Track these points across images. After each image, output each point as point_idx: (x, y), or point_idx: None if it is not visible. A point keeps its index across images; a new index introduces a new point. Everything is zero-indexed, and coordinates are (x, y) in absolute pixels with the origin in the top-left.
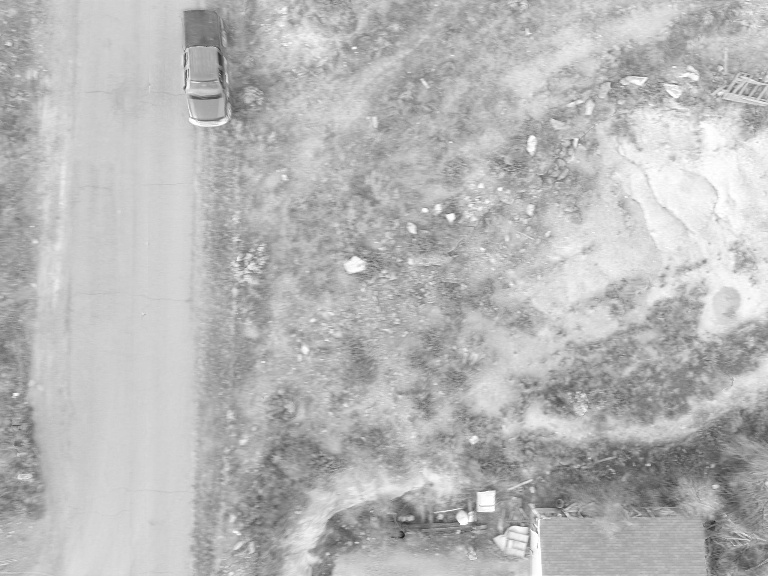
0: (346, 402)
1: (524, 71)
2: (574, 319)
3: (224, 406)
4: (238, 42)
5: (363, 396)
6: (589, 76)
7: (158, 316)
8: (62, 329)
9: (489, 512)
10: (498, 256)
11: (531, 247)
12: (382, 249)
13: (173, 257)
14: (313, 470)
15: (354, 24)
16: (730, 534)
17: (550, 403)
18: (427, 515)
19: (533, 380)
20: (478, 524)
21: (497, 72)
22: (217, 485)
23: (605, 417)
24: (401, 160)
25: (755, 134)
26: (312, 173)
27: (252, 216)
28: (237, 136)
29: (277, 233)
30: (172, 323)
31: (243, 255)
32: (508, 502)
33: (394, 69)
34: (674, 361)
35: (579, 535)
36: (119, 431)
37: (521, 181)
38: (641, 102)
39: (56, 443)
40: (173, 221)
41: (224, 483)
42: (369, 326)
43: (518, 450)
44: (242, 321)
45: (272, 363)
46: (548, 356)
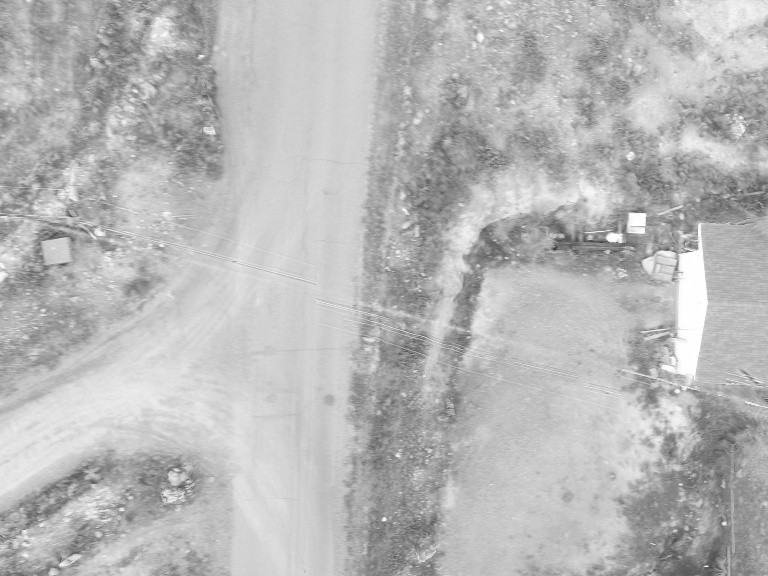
0: (513, 99)
1: None
2: (732, 48)
3: (401, 83)
4: None
5: (529, 96)
6: None
7: None
8: None
9: (638, 236)
10: None
11: None
12: None
13: None
14: (479, 163)
15: None
16: None
17: (707, 125)
18: (577, 234)
19: (691, 102)
20: (628, 245)
21: None
22: (391, 159)
23: (758, 148)
24: None
25: None
26: None
27: None
28: None
29: None
30: None
31: None
32: (657, 228)
33: None
34: None
35: (740, 238)
36: (298, 100)
37: None
38: None
39: (237, 108)
40: None
41: (398, 158)
42: (543, 20)
43: (673, 170)
44: (423, 0)
45: (448, 46)
46: (705, 82)
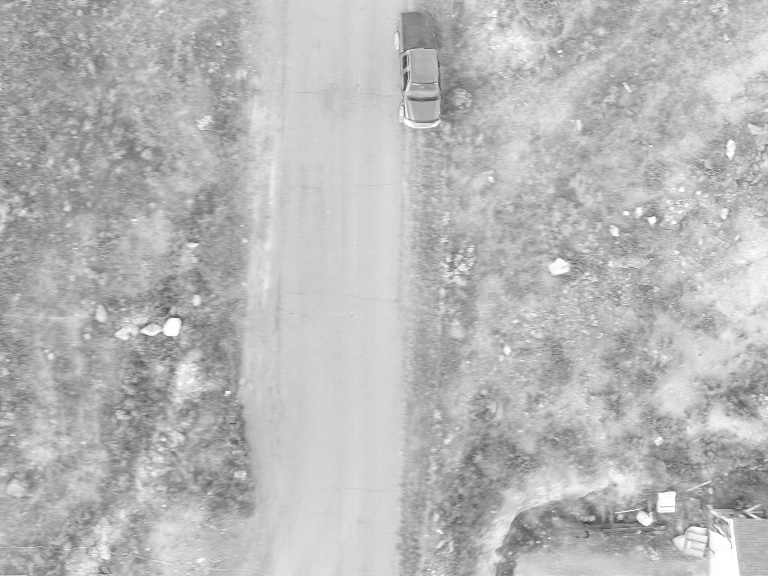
0: (542, 403)
1: (722, 76)
2: (755, 322)
3: (431, 406)
4: (445, 44)
5: (557, 397)
6: None
7: (366, 316)
8: (272, 328)
9: (668, 513)
10: (689, 259)
11: (721, 250)
12: (586, 251)
13: (381, 257)
14: (509, 470)
15: (560, 28)
16: None
17: (733, 405)
18: (608, 515)
19: (716, 382)
20: (658, 524)
21: (696, 77)
22: (423, 484)
23: None
24: (603, 163)
25: None
26: (517, 175)
27: (459, 217)
28: (445, 138)
29: (483, 234)
30: (380, 323)
31: (452, 256)
32: (686, 503)
33: (598, 73)
34: None
35: None
36: (328, 430)
37: (719, 185)
38: None
39: (266, 441)
40: (382, 222)
41: (430, 482)
42: (569, 327)
43: (701, 451)
44: (449, 321)
45: (476, 363)
46: (729, 358)
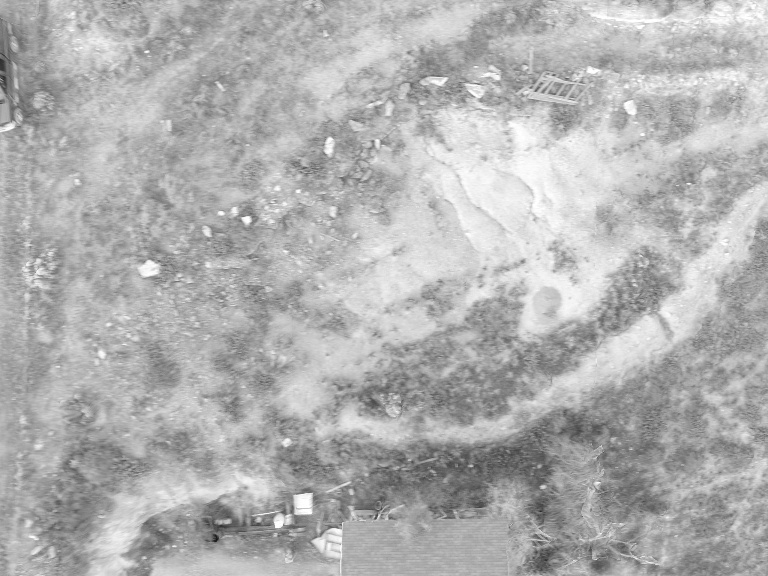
0: (149, 406)
1: (323, 73)
2: (390, 320)
3: (17, 411)
4: (31, 47)
5: (168, 400)
6: (388, 77)
7: None
8: None
9: (308, 515)
10: (304, 258)
11: (338, 249)
12: (176, 253)
13: None
14: (116, 474)
15: (146, 28)
16: (530, 535)
17: (364, 405)
18: (245, 518)
19: (347, 382)
20: (296, 527)
21: (294, 74)
22: (11, 490)
23: (423, 418)
24: (197, 163)
25: (567, 133)
26: (106, 177)
27: (45, 221)
28: (28, 141)
29: (70, 238)
30: None
31: (34, 260)
32: (327, 504)
33: (188, 72)
34: (494, 362)
35: (382, 537)
36: None
37: (320, 183)
38: (443, 102)
39: None
40: None
41: (18, 488)
42: (168, 330)
43: (332, 452)
44: (35, 326)
45: (67, 368)
46: (364, 358)
